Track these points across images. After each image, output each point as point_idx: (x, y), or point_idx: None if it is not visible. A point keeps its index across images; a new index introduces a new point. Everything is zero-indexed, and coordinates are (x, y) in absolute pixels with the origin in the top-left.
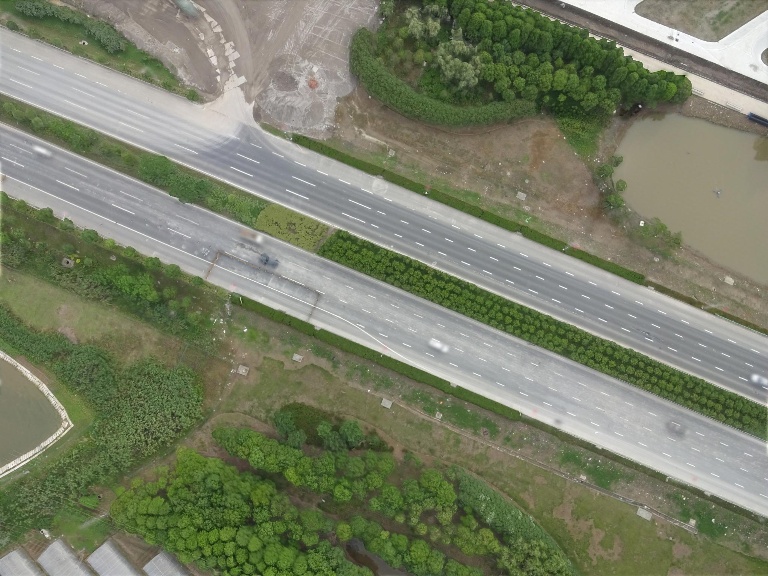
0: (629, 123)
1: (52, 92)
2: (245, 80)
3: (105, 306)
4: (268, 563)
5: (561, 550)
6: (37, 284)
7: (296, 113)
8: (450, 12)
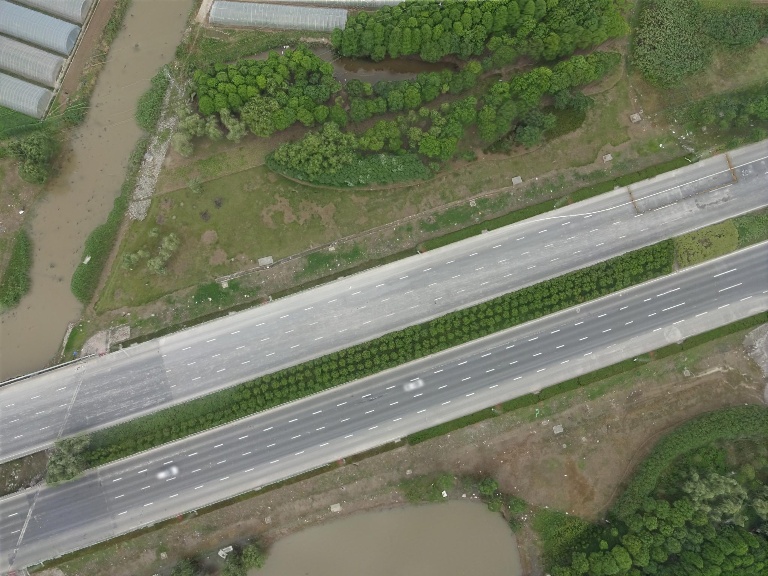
0: None
1: None
2: None
3: None
4: (514, 1)
5: (311, 182)
6: None
7: None
8: (763, 536)
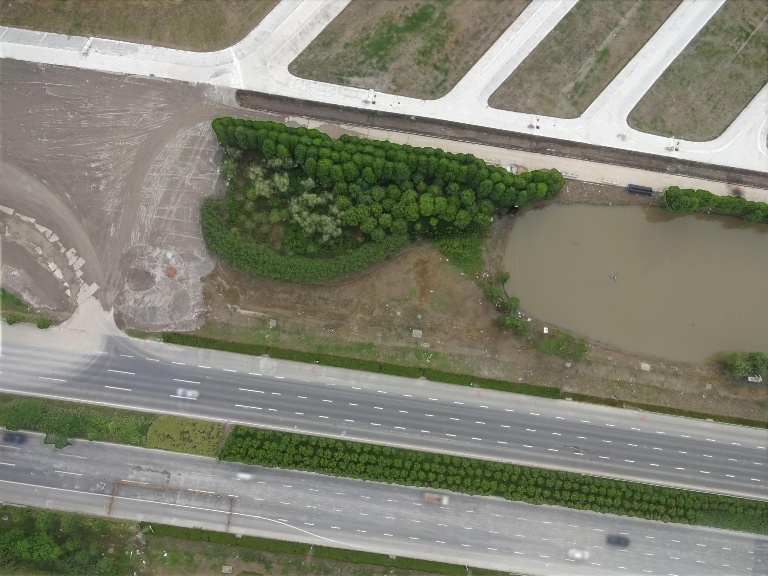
0: (509, 227)
1: None
2: (97, 287)
3: (10, 571)
4: None
5: None
6: None
7: (160, 312)
8: (295, 161)
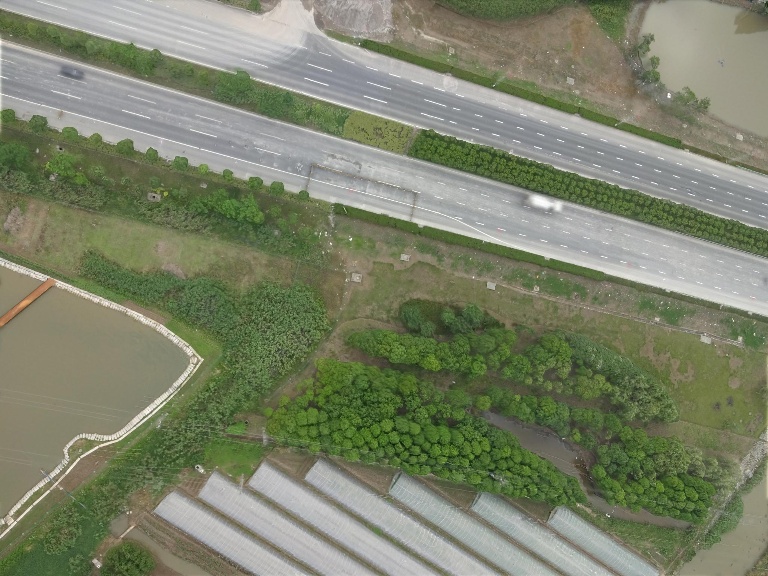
0: (646, 5)
1: (91, 13)
2: None
3: (206, 236)
4: (434, 441)
5: None
6: (125, 224)
7: (360, 16)
8: None
